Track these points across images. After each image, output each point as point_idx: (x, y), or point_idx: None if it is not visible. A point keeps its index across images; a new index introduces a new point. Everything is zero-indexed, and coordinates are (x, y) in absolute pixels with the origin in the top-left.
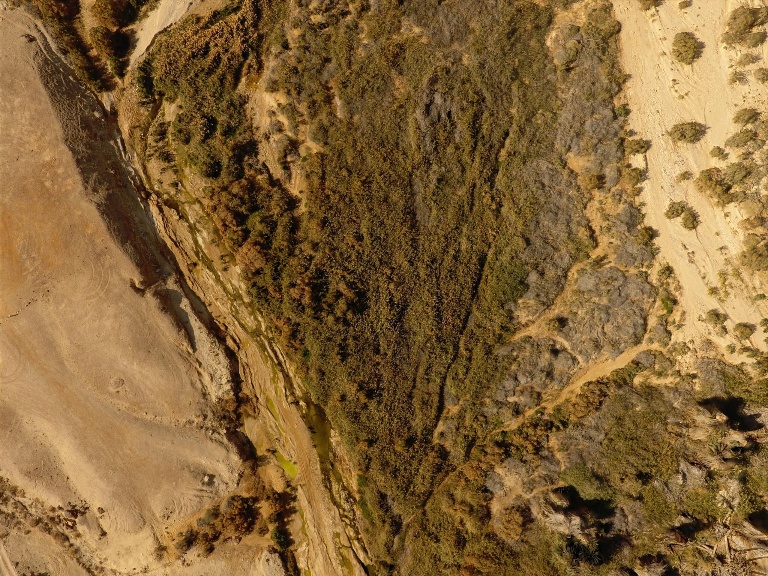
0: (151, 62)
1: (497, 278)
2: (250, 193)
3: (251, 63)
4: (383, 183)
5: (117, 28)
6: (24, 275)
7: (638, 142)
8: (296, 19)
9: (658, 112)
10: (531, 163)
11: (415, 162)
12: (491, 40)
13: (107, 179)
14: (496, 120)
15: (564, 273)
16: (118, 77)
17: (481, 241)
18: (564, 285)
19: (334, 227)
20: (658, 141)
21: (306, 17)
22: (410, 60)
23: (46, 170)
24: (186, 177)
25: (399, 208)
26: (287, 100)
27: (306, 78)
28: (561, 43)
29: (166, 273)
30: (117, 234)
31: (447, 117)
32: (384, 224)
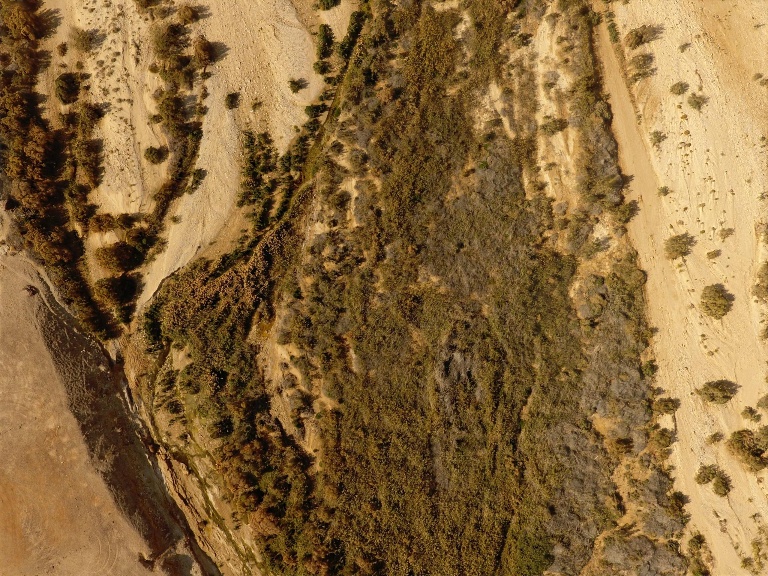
0: (158, 308)
1: (521, 551)
2: (262, 454)
3: (262, 313)
4: (401, 447)
5: (123, 273)
6: (28, 551)
7: (667, 404)
8: (309, 267)
9: (687, 369)
10: (555, 426)
11: (434, 424)
12: (512, 293)
13: (114, 440)
14: (518, 378)
15: (591, 544)
16: (124, 323)
17: (504, 510)
18: (591, 554)
19: (350, 493)
20: (687, 400)
21: (319, 265)
22: (428, 313)
23: (50, 439)
24: (195, 429)
25: (418, 473)
26: (300, 353)
27: (320, 332)
28: (585, 296)
29: (176, 537)
30: (125, 505)
31: (467, 376)
32: (402, 490)
